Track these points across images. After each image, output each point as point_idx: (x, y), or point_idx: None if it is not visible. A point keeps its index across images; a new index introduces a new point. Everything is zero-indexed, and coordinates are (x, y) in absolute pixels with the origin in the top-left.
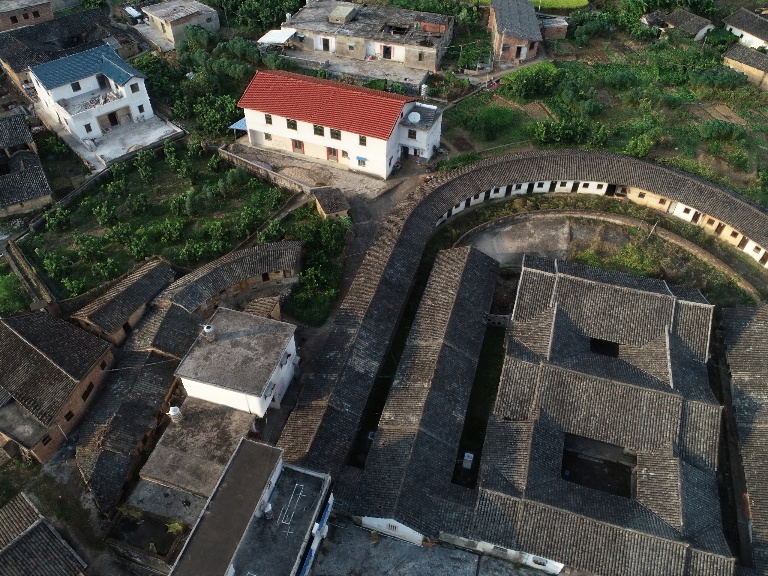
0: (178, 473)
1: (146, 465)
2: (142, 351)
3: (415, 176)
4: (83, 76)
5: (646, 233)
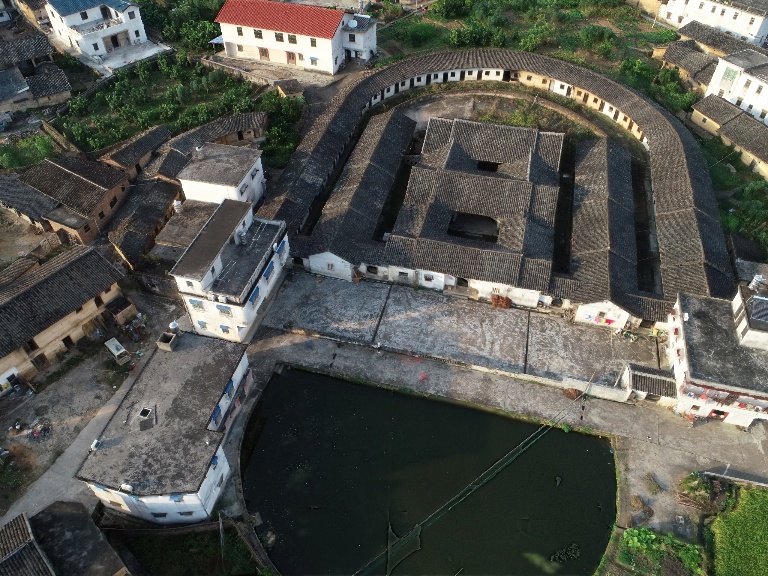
0: (182, 238)
1: (159, 235)
2: (151, 179)
3: (356, 72)
4: (90, 7)
5: (530, 103)
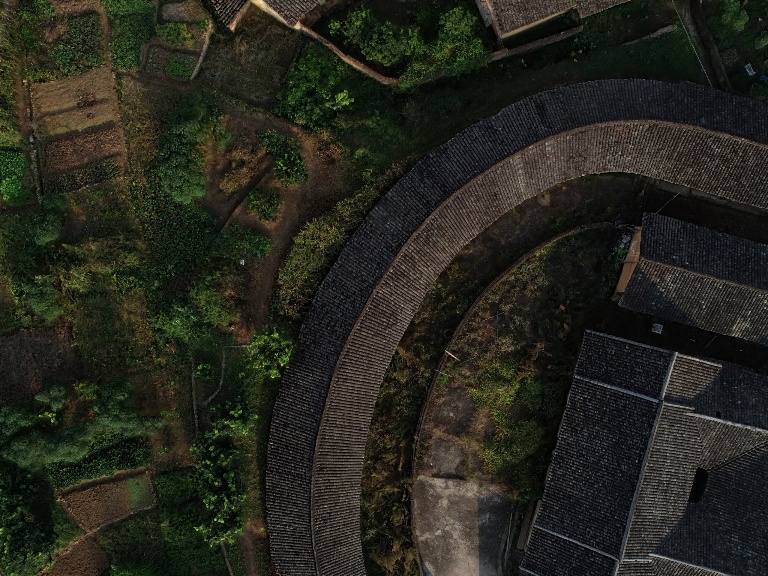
0: None
1: None
2: None
3: None
4: None
5: None
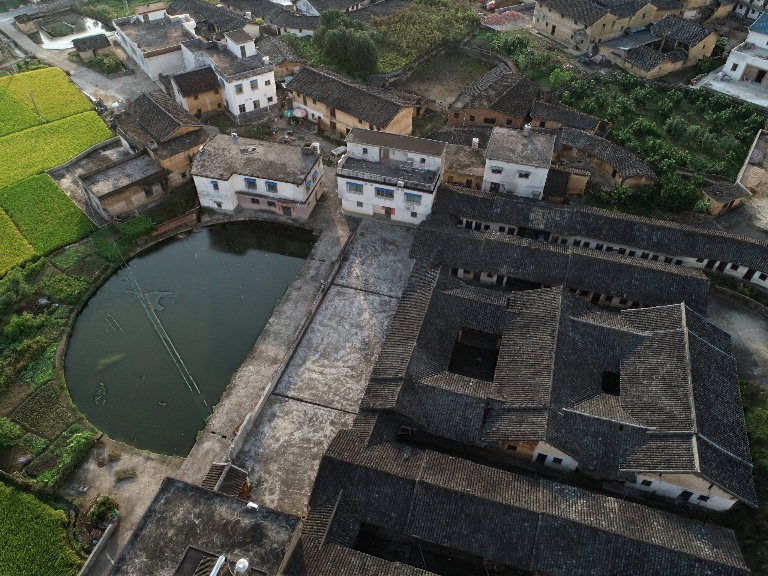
0: None
1: None
2: None
3: None
4: None
5: None
